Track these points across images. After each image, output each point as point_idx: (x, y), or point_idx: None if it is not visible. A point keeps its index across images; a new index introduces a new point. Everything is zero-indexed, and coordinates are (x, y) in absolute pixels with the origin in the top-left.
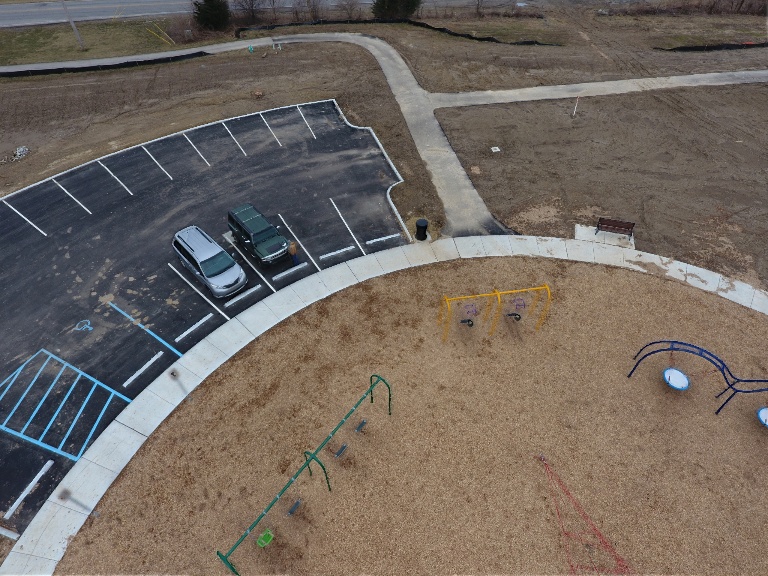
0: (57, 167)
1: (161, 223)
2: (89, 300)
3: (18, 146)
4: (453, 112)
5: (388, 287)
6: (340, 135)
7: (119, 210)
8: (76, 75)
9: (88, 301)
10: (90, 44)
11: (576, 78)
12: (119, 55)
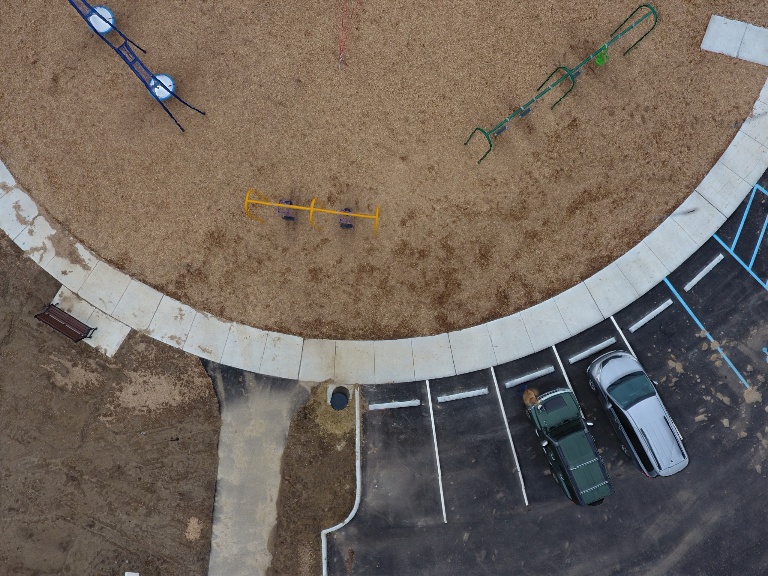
0: None
1: (694, 531)
2: None
3: None
4: None
5: (415, 313)
6: None
7: None
8: None
9: None
10: None
11: None
12: None
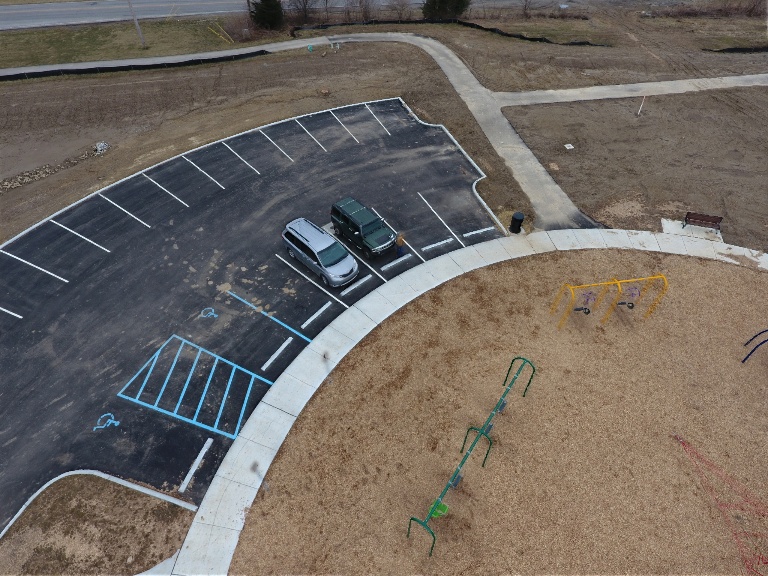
0: (144, 162)
1: (259, 216)
2: (207, 289)
3: (96, 141)
4: (520, 110)
5: (494, 277)
6: (414, 132)
7: (215, 203)
8: (143, 72)
9: (207, 290)
10: (150, 42)
11: (632, 78)
12: (181, 53)
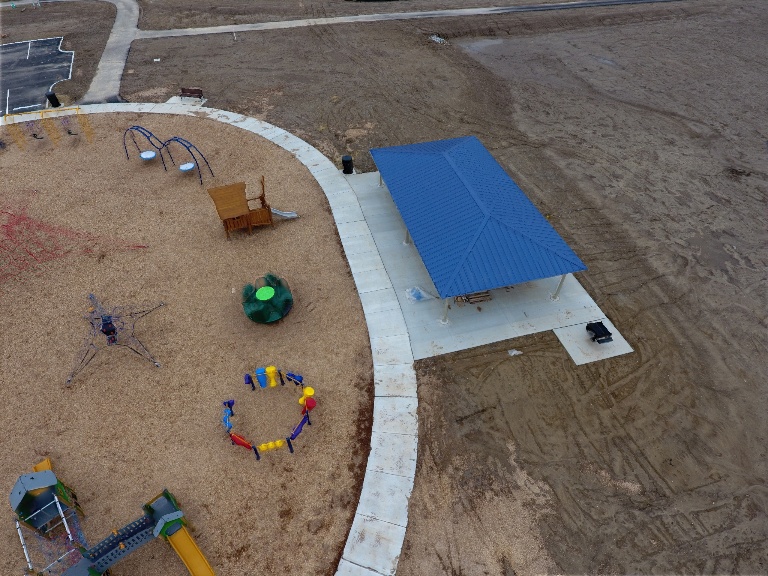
0: None
1: None
2: None
3: None
4: (147, 41)
5: (8, 129)
6: (48, 56)
7: None
8: None
9: None
10: None
11: (266, 19)
12: None
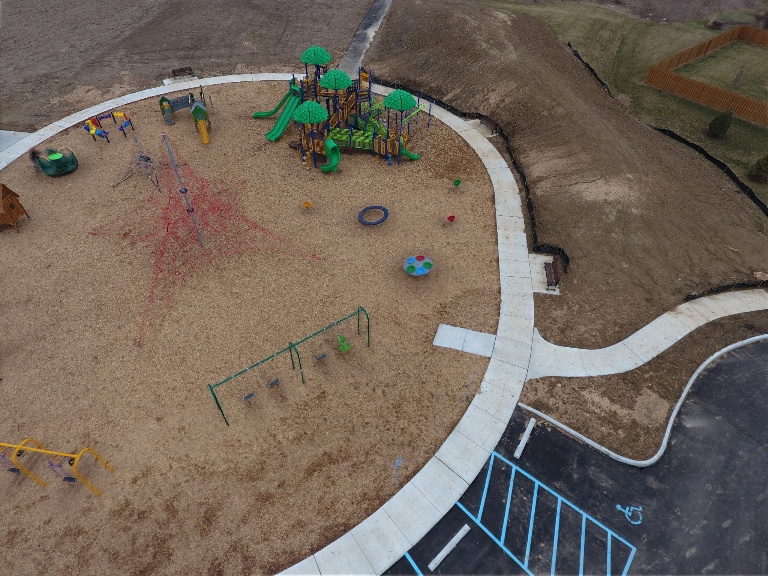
0: None
1: None
2: None
3: None
4: None
5: None
6: None
7: None
8: None
9: None
10: None
11: None
12: None
